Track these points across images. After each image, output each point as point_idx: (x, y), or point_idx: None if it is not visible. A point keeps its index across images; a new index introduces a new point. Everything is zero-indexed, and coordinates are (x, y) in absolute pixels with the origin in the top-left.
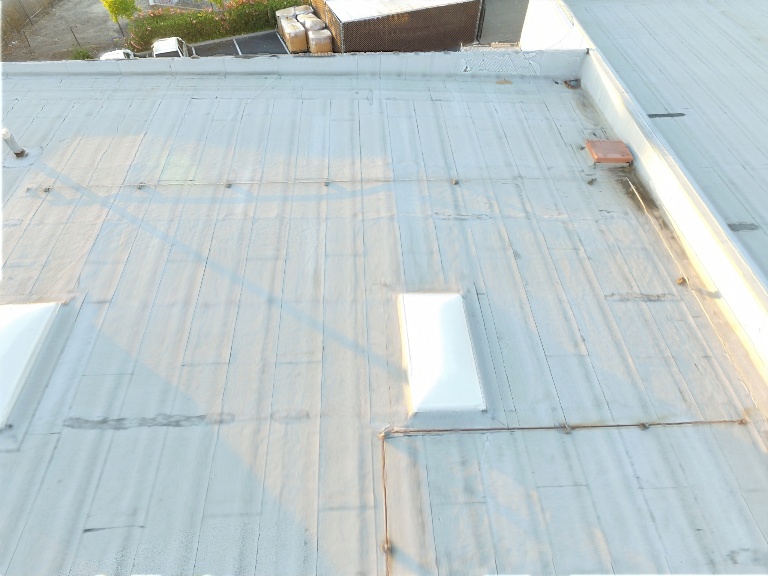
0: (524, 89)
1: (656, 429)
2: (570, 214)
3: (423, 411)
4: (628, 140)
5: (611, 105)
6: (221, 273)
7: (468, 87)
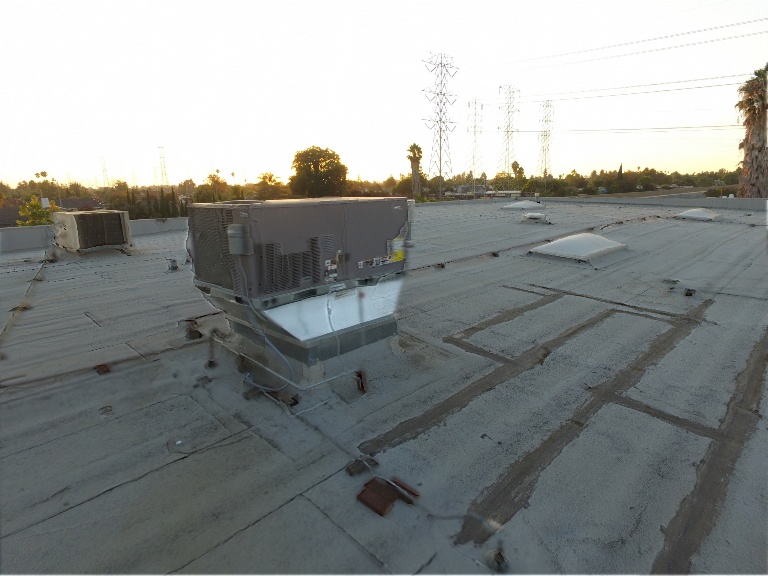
0: None
1: None
2: None
3: (679, 216)
4: None
5: None
6: (606, 210)
7: None
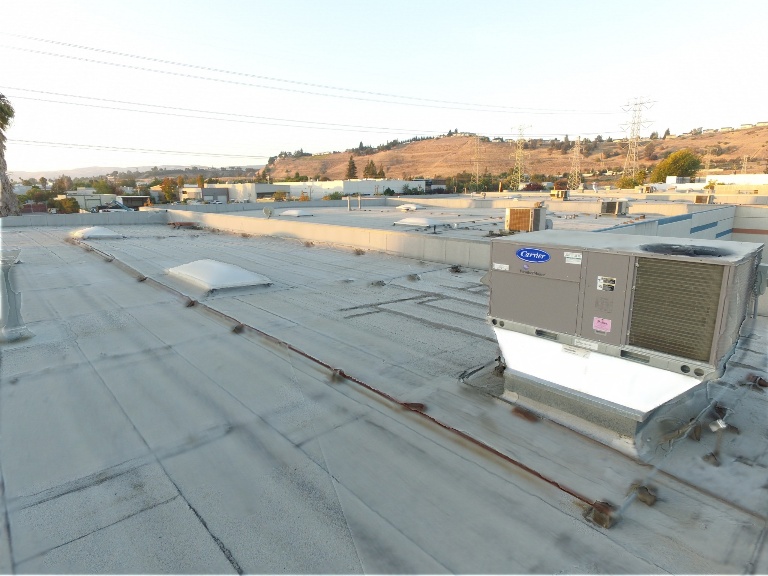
0: (142, 225)
1: (202, 236)
2: (167, 230)
3: (92, 236)
4: (195, 221)
5: (186, 218)
6: None
7: (108, 225)
